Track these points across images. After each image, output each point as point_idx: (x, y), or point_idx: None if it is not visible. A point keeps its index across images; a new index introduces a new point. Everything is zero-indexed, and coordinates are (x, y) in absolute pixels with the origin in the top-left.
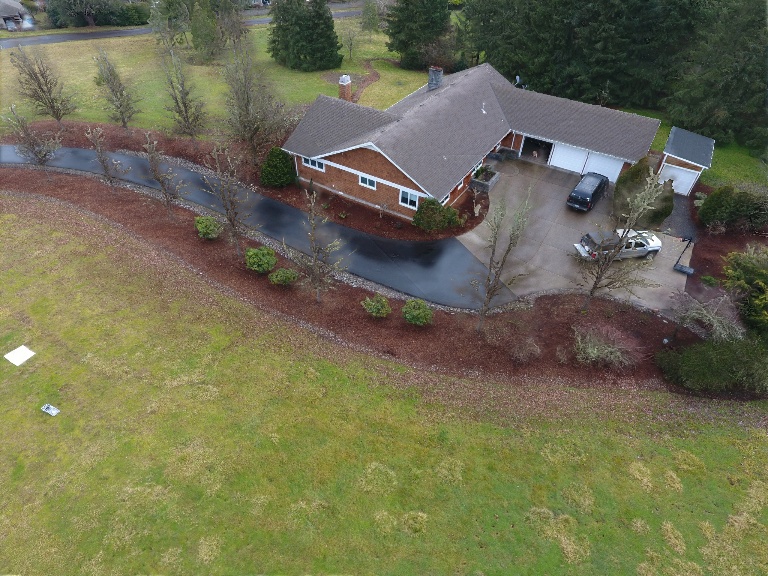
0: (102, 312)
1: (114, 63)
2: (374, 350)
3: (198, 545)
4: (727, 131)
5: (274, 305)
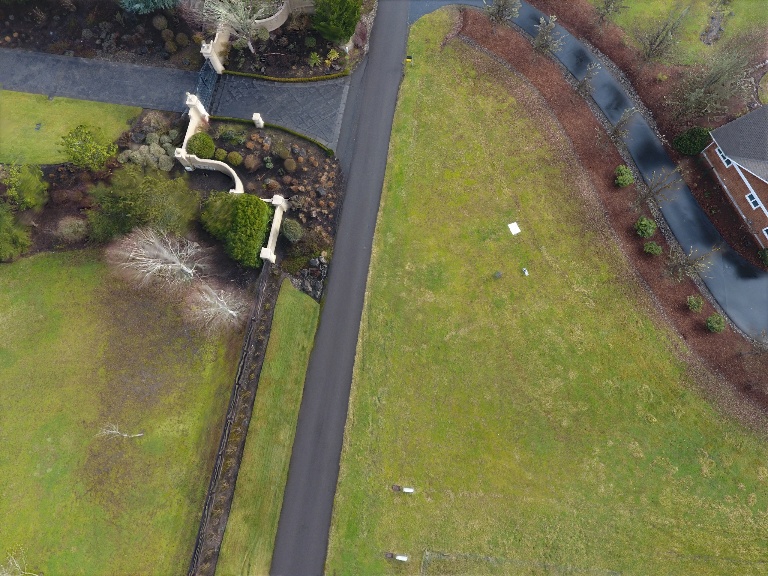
0: (553, 220)
1: None
2: (677, 329)
3: (569, 371)
4: None
5: (638, 265)
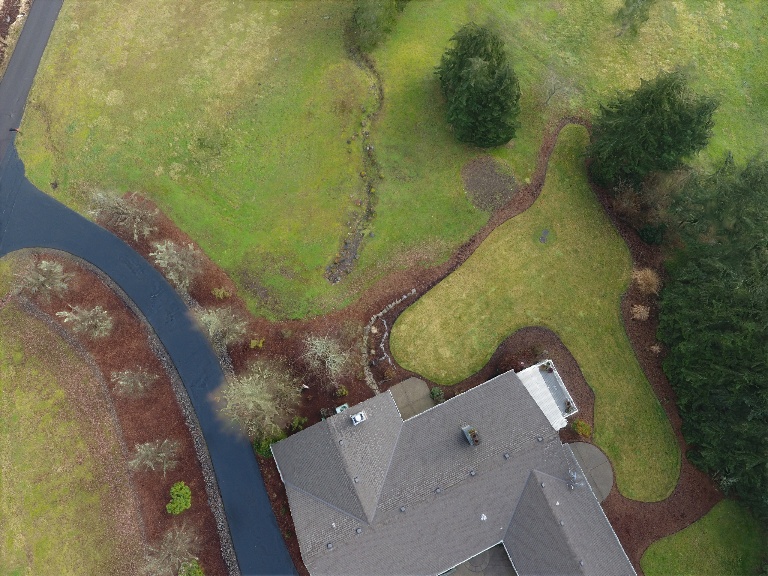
0: None
1: (269, 1)
2: None
3: None
4: None
5: None
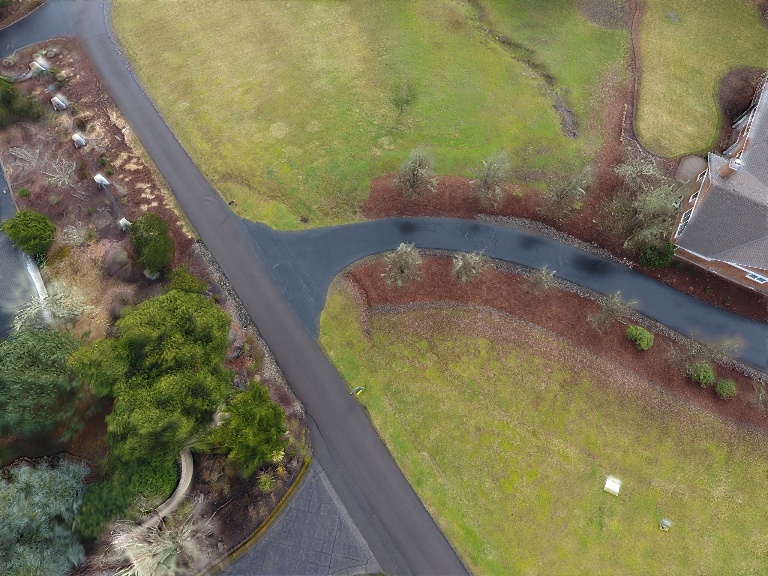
0: (632, 444)
1: None
2: None
3: None
4: None
5: (728, 418)
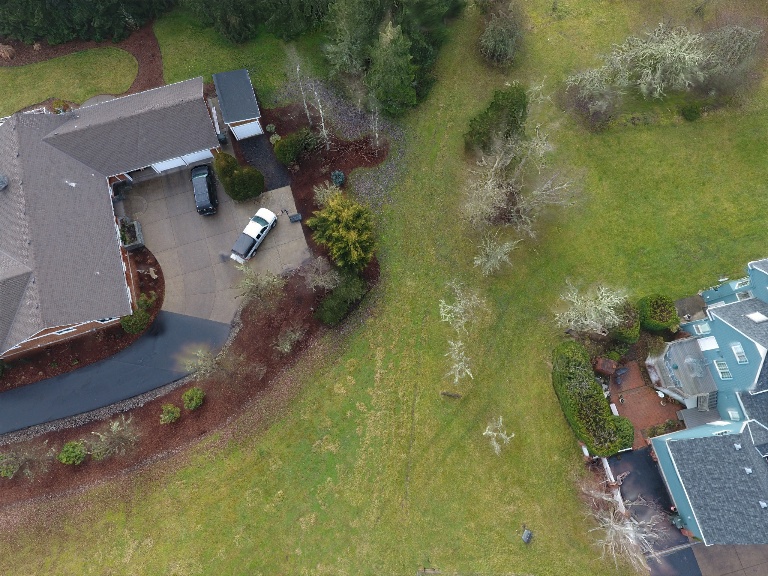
0: (36, 575)
1: None
2: (194, 439)
3: None
4: (248, 26)
5: (117, 468)
